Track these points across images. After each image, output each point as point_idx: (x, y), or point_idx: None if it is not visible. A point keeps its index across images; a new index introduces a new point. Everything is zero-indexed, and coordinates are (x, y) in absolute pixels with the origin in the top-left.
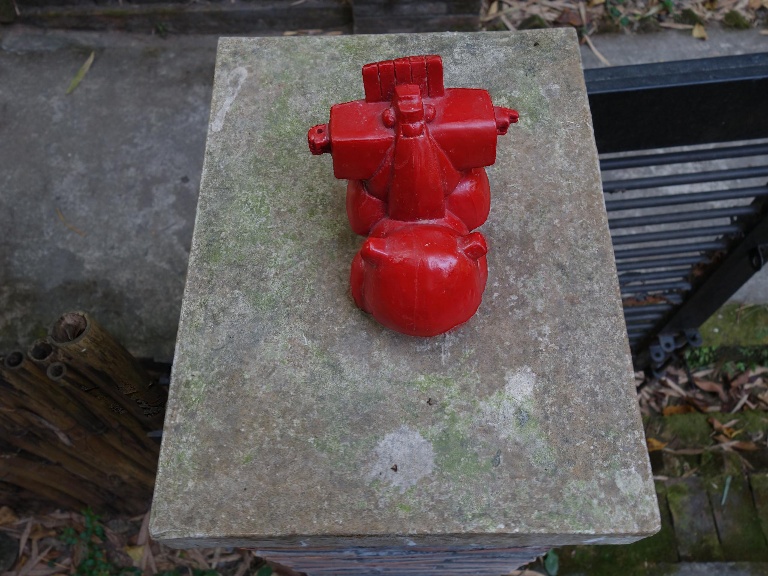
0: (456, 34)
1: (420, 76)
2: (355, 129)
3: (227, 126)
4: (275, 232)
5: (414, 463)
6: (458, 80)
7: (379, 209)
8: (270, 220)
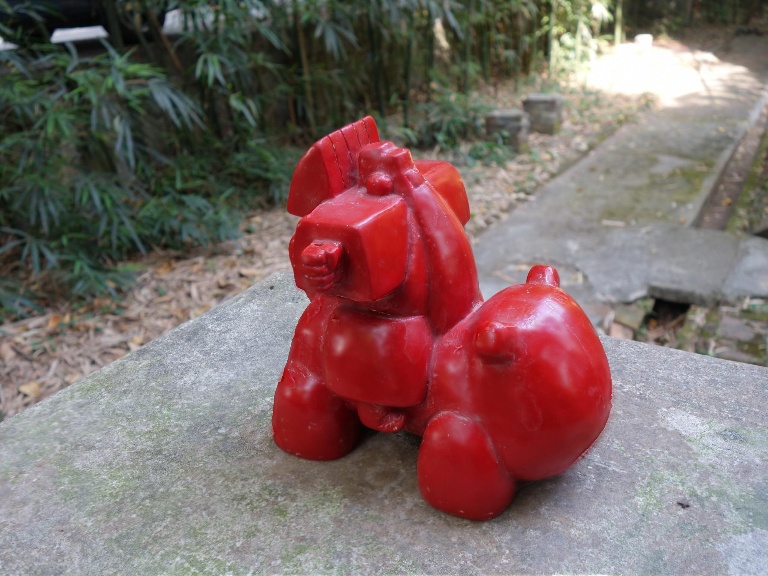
0: (192, 321)
1: (365, 141)
2: (362, 209)
3: (8, 553)
4: (267, 569)
5: None
6: (246, 337)
7: (425, 331)
8: (239, 567)
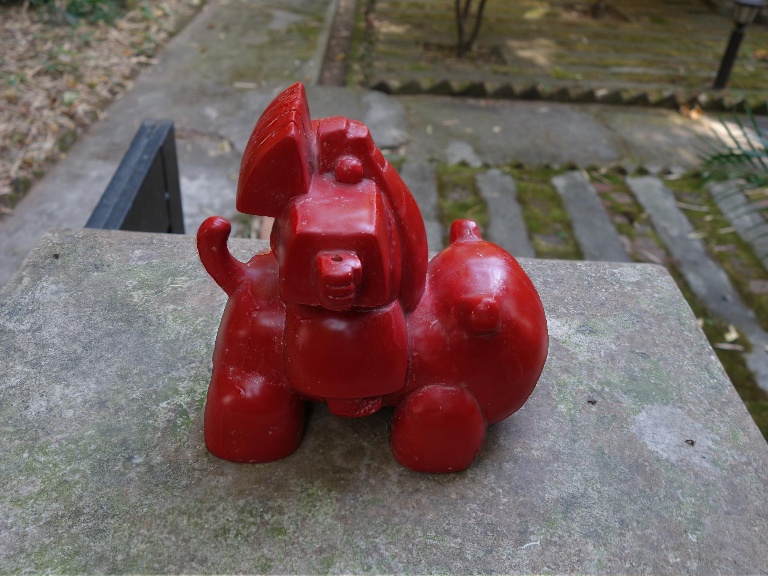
0: None
1: None
2: (358, 207)
3: None
4: None
5: (675, 424)
6: (72, 331)
7: (401, 314)
8: None
